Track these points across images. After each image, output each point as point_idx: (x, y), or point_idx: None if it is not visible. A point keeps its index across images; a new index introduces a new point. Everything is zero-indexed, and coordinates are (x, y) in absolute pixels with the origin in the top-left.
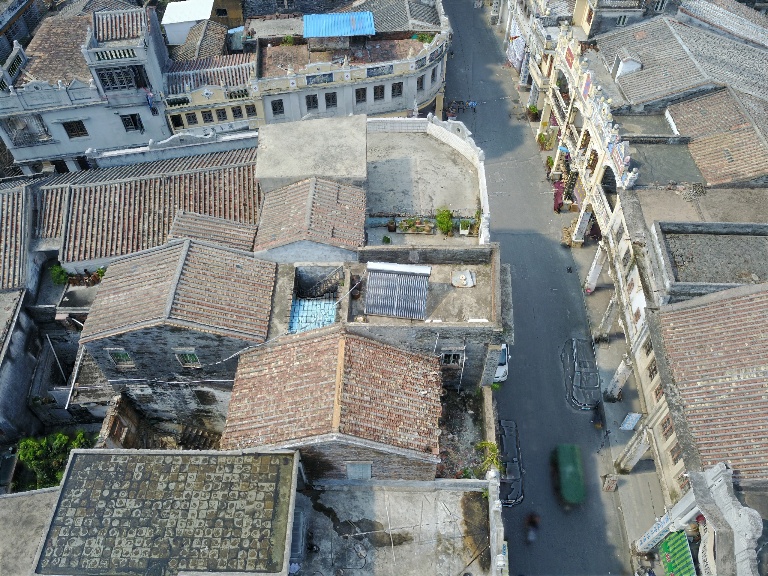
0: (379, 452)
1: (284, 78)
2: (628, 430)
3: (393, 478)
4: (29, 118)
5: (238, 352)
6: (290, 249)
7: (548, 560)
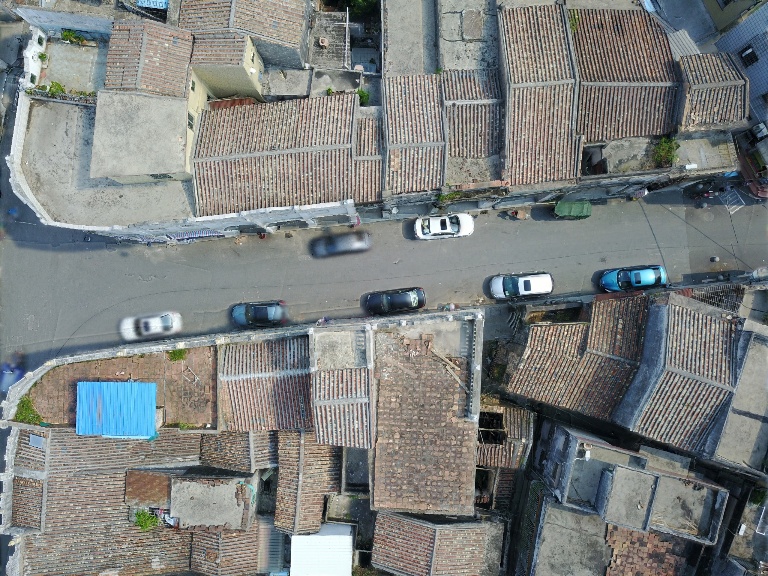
0: None
1: (189, 342)
2: (5, 43)
3: None
4: None
5: None
6: None
7: None
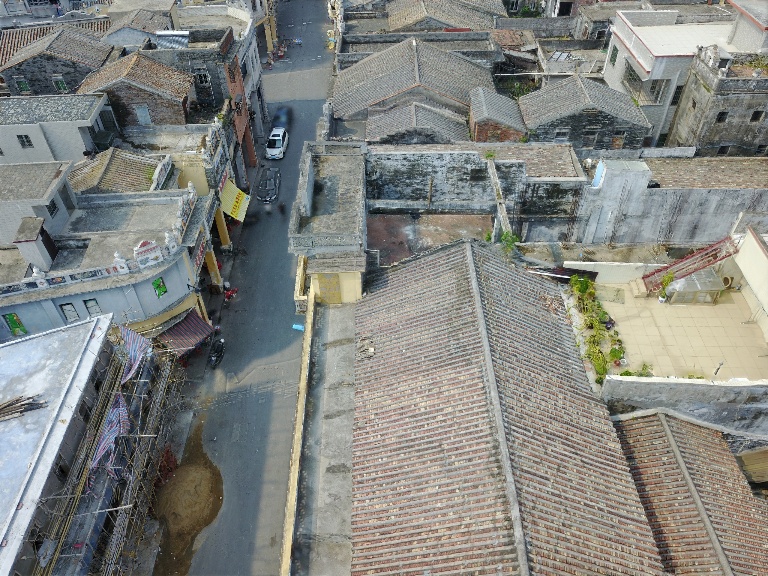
0: (148, 94)
1: None
2: None
3: (164, 123)
4: None
5: (86, 77)
6: (119, 35)
7: (285, 222)
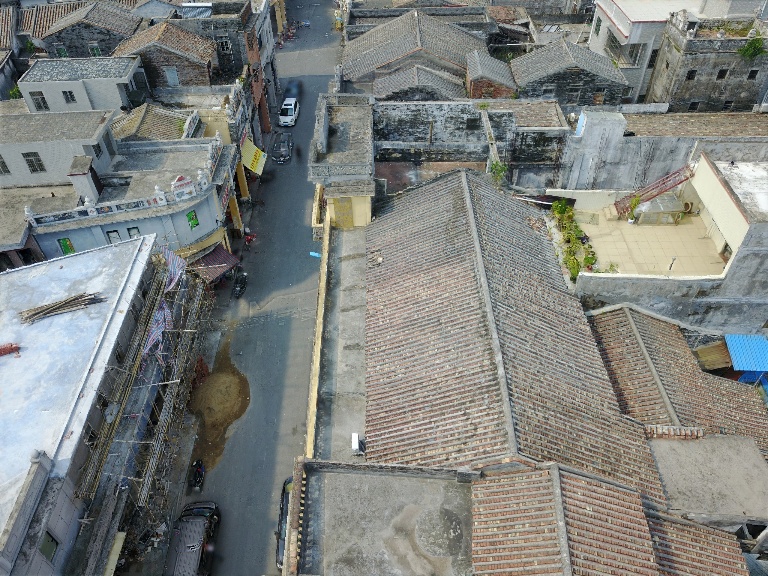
0: (177, 56)
1: None
2: None
3: (190, 84)
4: (13, 3)
5: (119, 44)
6: (148, 7)
7: (298, 180)
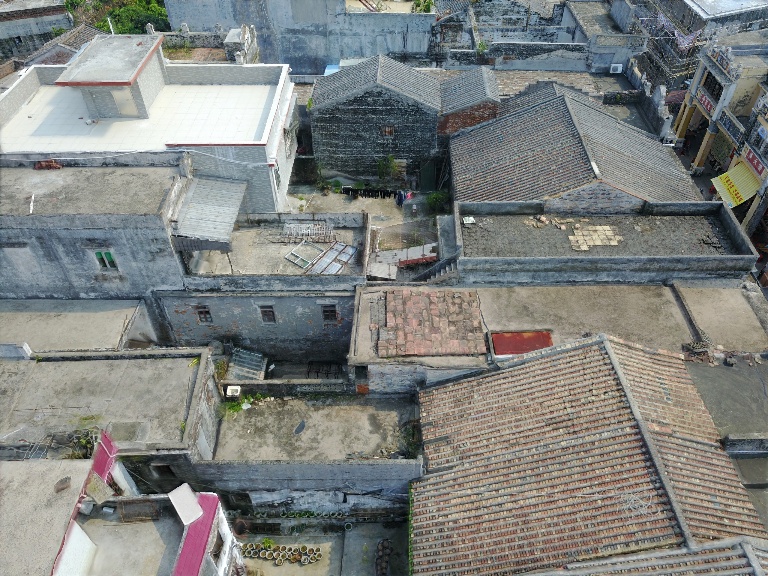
0: None
1: None
2: None
3: None
4: None
5: None
6: None
7: None
